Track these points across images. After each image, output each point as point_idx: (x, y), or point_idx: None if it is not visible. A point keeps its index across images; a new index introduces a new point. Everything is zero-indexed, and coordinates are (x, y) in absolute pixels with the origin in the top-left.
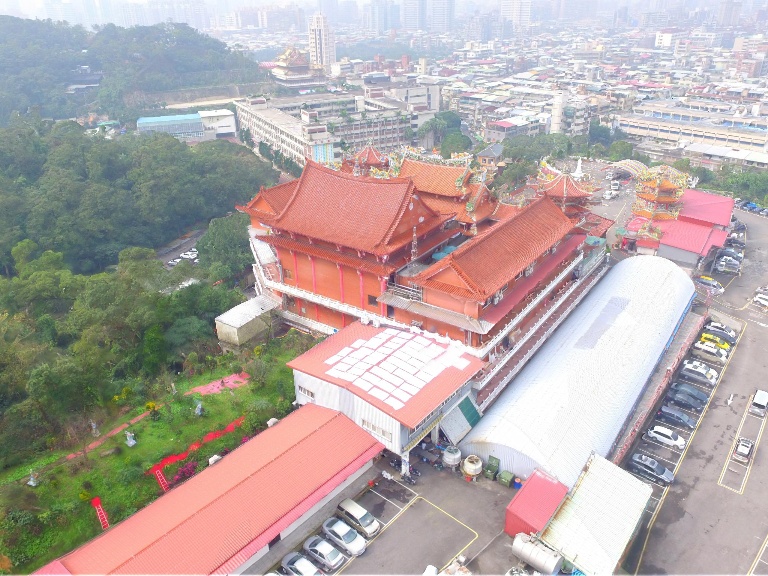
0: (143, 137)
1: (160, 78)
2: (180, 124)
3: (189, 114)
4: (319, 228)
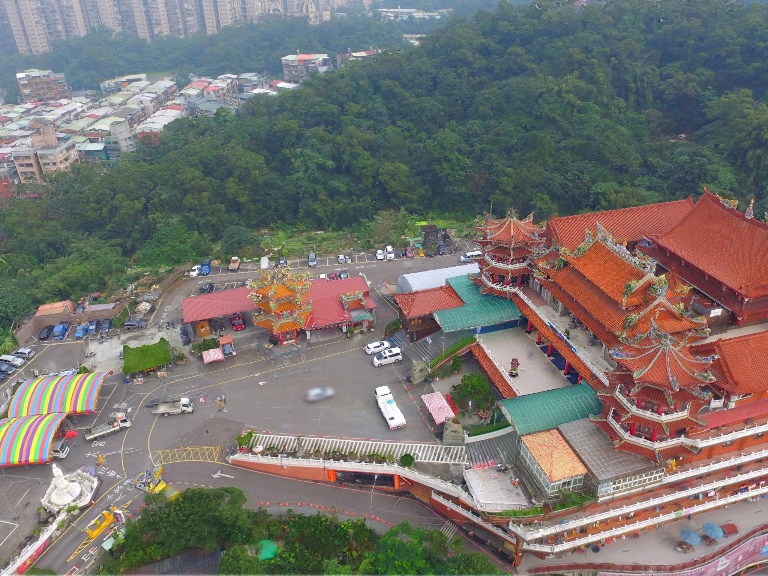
0: None
1: None
2: None
3: None
4: None
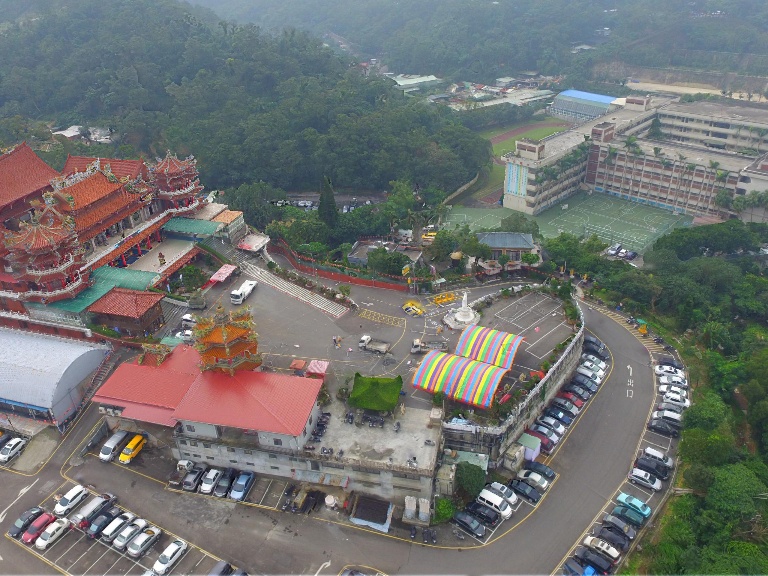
0: (416, 107)
1: (645, 52)
2: (588, 105)
3: (612, 97)
4: None
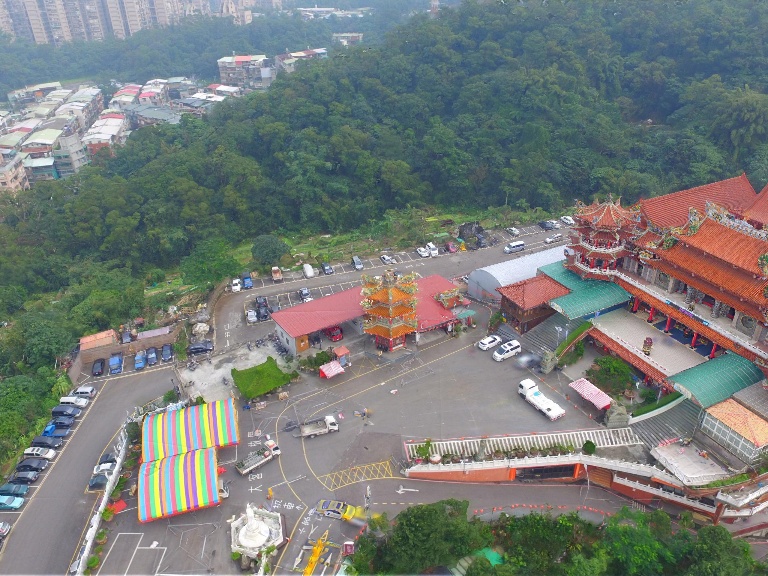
0: None
1: None
2: None
3: None
4: None
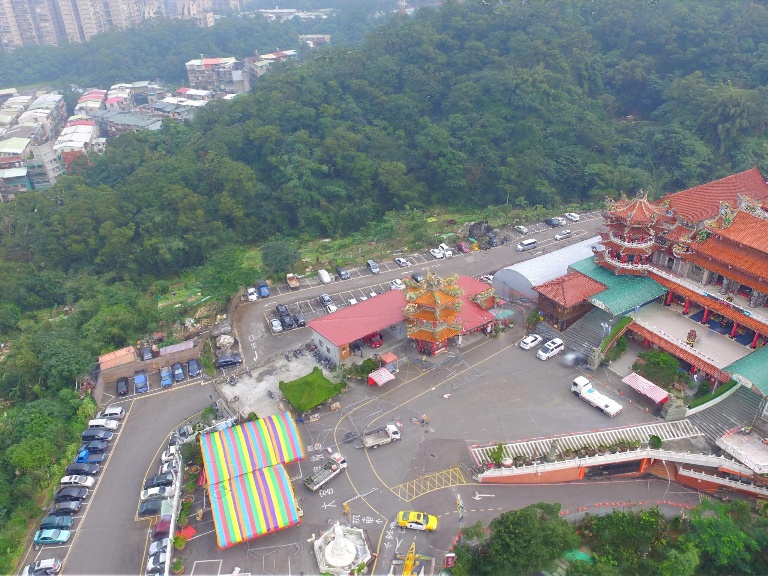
0: None
1: None
2: None
3: None
4: None
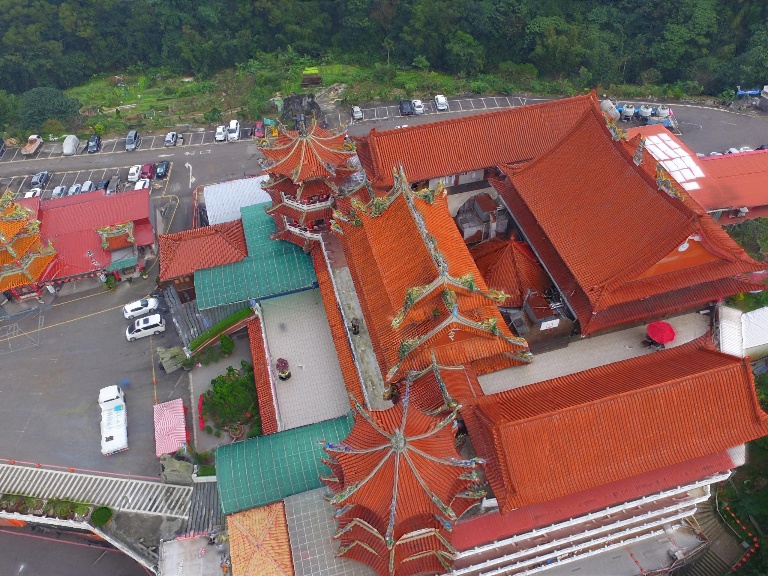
0: None
1: None
2: None
3: None
4: (689, 205)
